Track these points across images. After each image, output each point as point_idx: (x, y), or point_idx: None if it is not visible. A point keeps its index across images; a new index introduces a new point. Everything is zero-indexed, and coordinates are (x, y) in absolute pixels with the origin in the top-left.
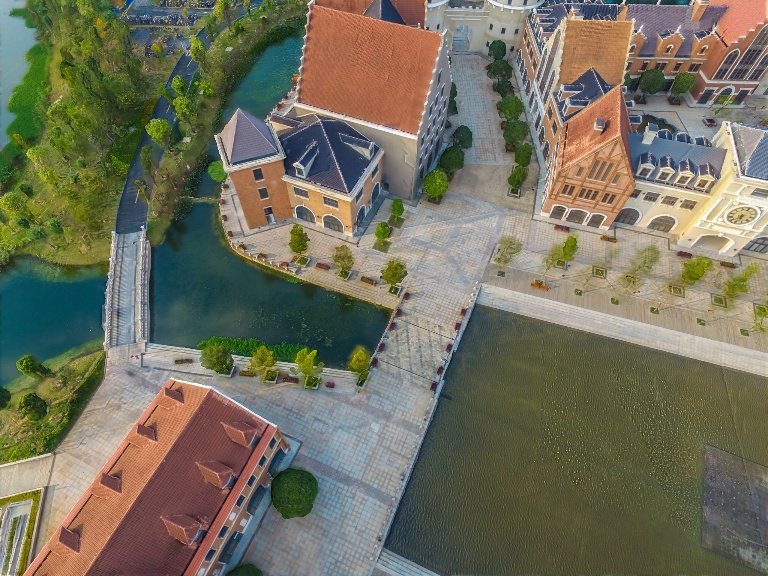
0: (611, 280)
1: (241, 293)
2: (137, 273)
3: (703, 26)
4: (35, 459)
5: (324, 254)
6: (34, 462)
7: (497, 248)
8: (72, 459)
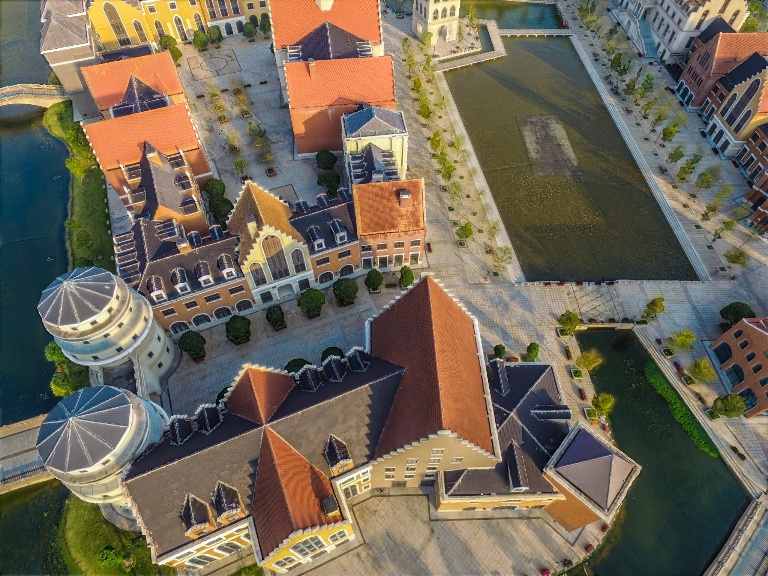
0: (458, 217)
1: (651, 455)
2: (728, 571)
3: (165, 162)
4: None
5: (570, 402)
6: None
7: (474, 282)
8: None
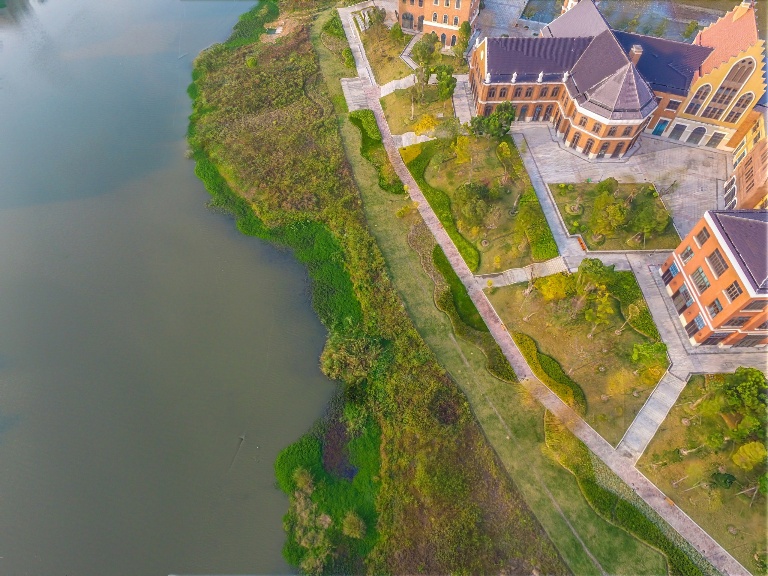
0: None
1: None
2: None
3: None
4: (365, 2)
5: None
6: (363, 5)
7: None
8: (381, 1)
